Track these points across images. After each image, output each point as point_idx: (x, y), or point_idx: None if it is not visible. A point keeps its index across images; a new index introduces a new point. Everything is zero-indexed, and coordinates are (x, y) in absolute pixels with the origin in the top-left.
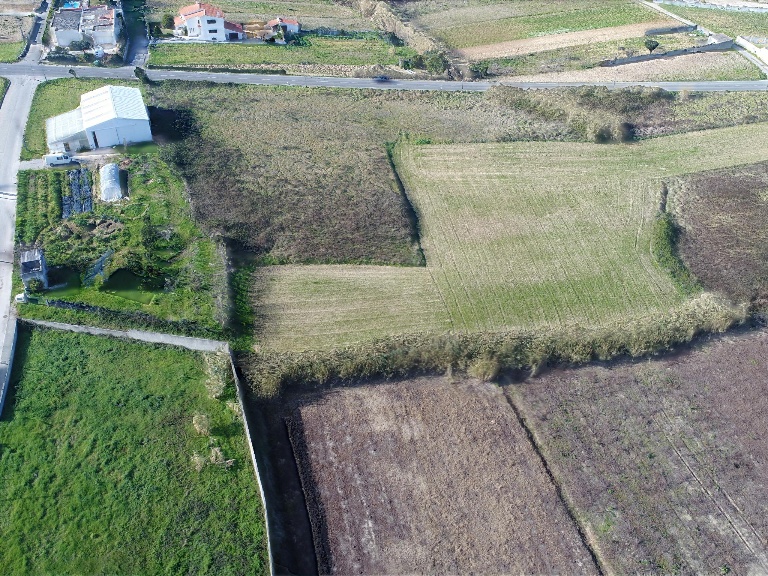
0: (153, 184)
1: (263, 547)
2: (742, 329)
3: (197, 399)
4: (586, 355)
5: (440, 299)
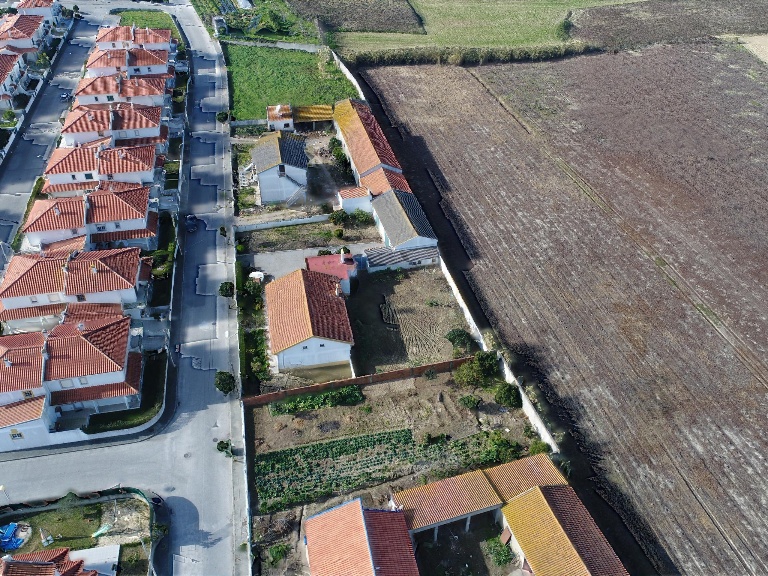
0: (268, 3)
1: (357, 95)
2: (593, 53)
3: (316, 64)
4: (508, 55)
5: (435, 44)
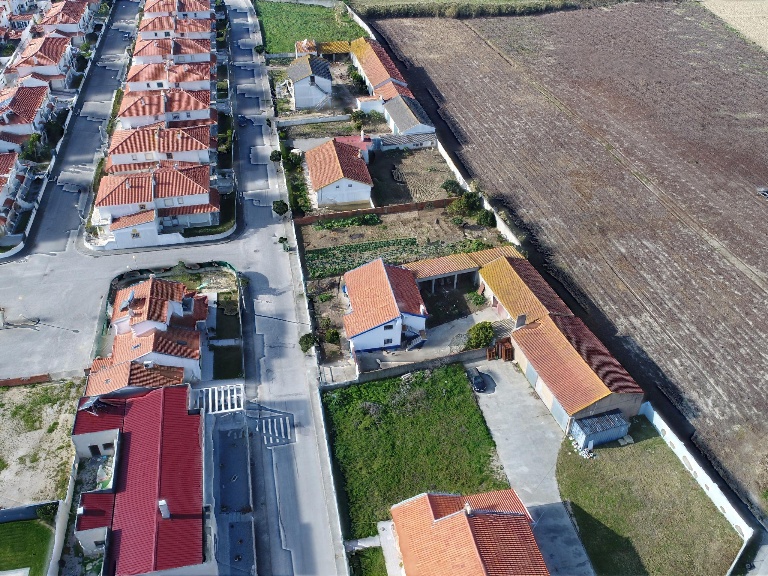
0: None
1: None
2: (570, 9)
3: (333, 16)
4: (497, 9)
5: None
